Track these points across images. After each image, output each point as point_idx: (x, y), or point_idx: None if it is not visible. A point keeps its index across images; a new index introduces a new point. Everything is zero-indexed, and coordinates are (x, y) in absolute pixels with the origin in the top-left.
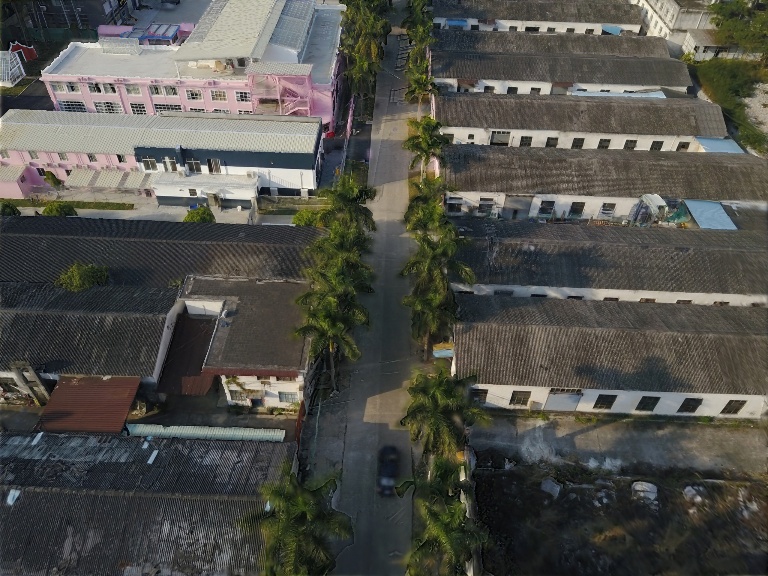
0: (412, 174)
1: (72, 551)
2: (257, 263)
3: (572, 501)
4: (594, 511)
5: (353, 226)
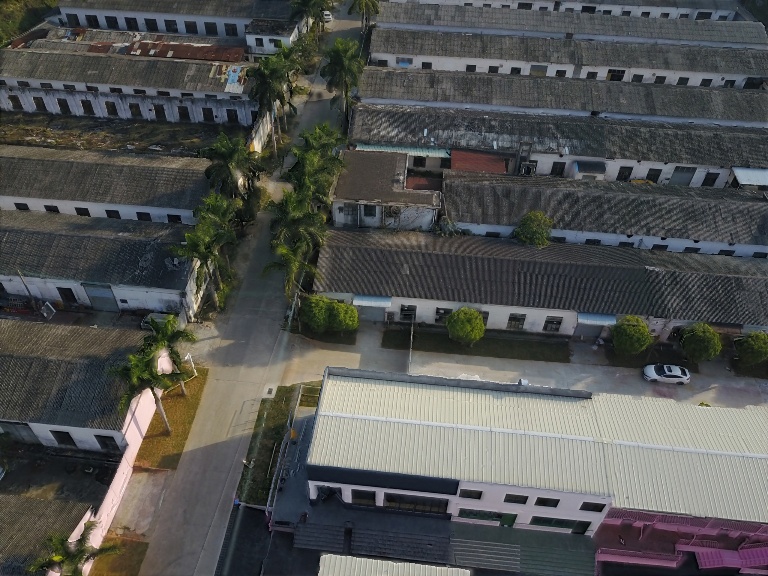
0: (173, 462)
1: (449, 110)
2: (386, 240)
3: (199, 148)
4: (190, 147)
5: (293, 196)
